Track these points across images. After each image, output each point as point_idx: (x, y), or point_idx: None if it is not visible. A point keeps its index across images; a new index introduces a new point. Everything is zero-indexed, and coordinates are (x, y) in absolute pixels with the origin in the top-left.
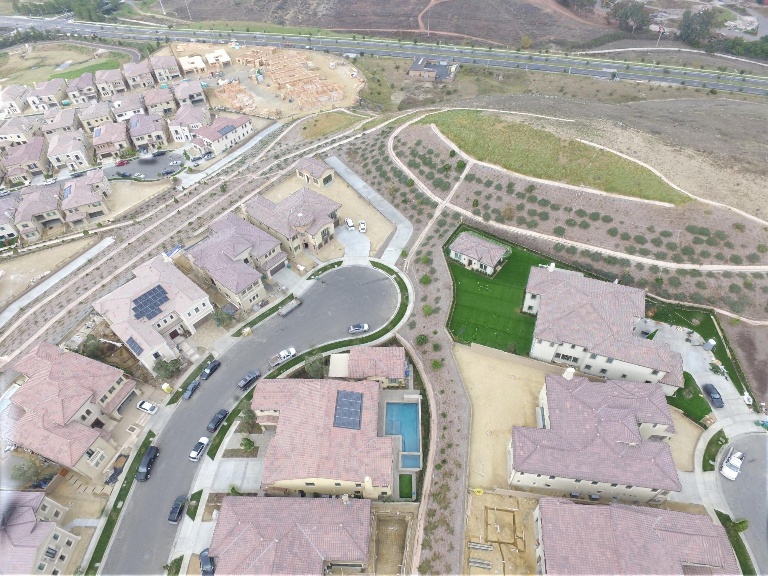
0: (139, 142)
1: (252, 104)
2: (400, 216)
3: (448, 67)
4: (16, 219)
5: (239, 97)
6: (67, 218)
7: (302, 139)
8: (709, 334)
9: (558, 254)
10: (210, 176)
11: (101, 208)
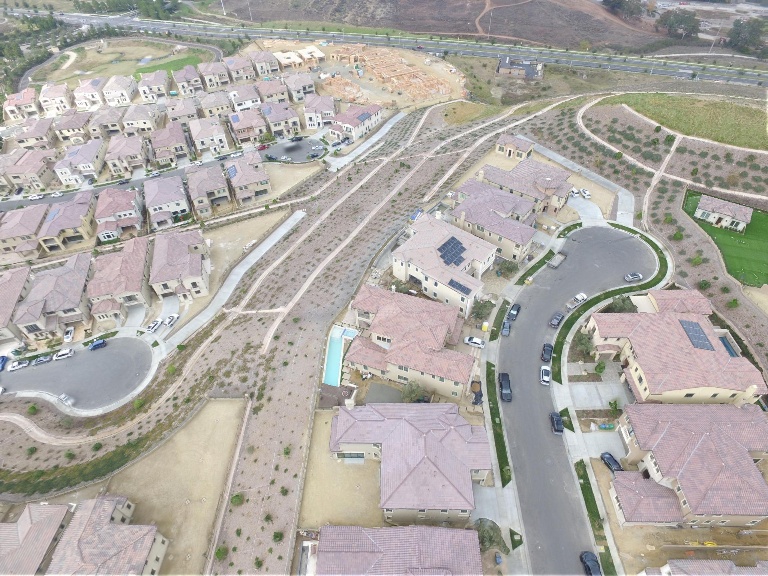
0: (276, 128)
1: (362, 96)
2: (615, 185)
3: (532, 66)
4: (192, 195)
5: (350, 89)
6: (238, 195)
7: (448, 125)
8: None
9: None
10: (359, 159)
11: (266, 186)
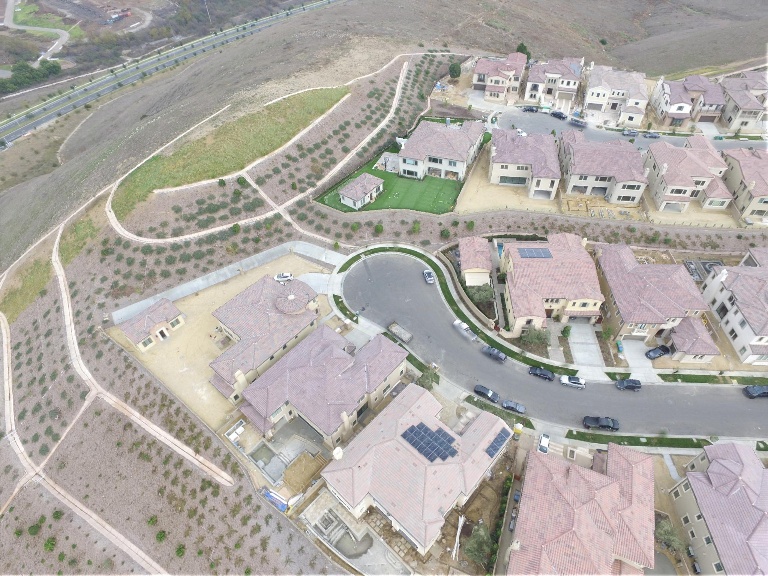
0: None
1: None
2: (275, 249)
3: None
4: None
5: None
6: None
7: None
8: (438, 121)
9: (365, 157)
10: None
11: None
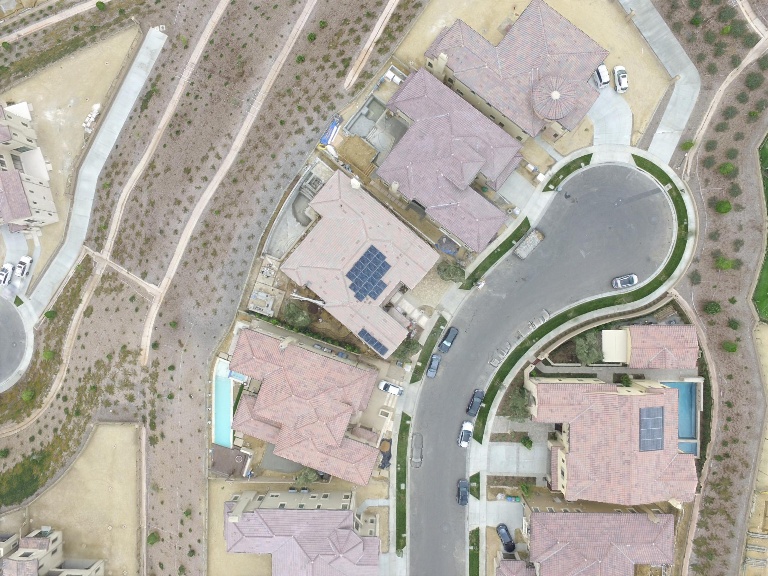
0: None
1: None
2: (681, 53)
3: None
4: None
5: None
6: None
7: None
8: None
9: None
10: None
11: None
